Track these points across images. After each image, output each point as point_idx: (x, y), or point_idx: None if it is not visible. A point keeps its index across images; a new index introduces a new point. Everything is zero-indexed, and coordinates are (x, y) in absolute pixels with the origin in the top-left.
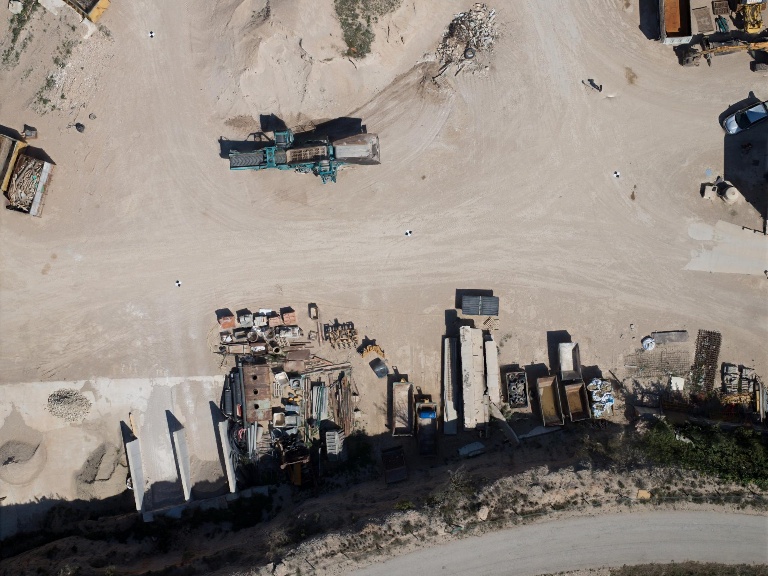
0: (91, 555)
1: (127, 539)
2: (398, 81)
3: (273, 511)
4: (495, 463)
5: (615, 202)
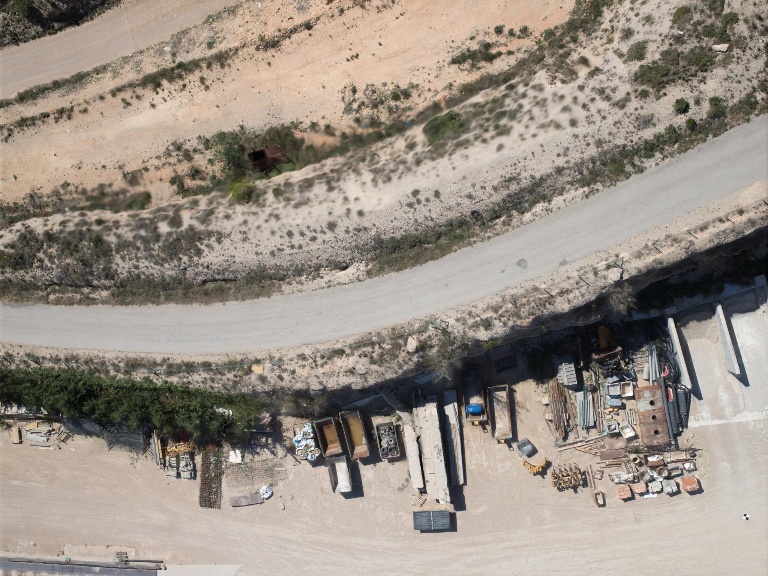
0: None
1: None
2: None
3: None
4: None
5: None
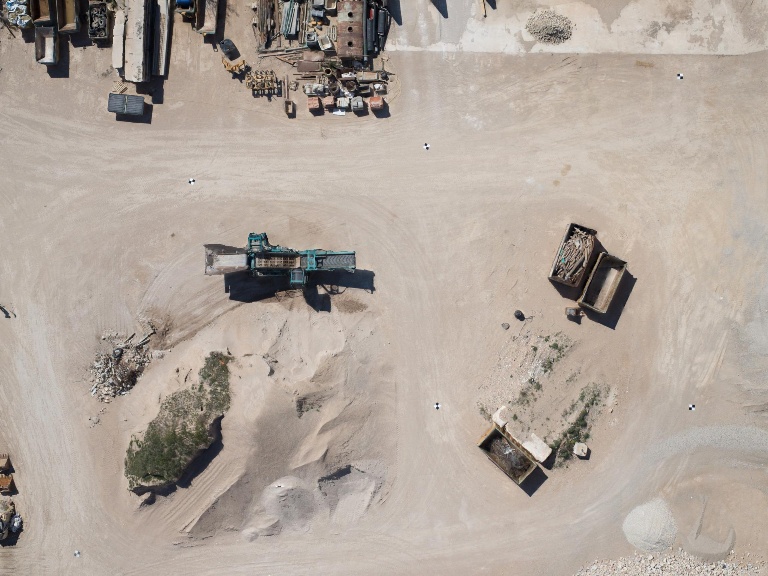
0: None
1: None
2: (191, 334)
3: None
4: None
5: None
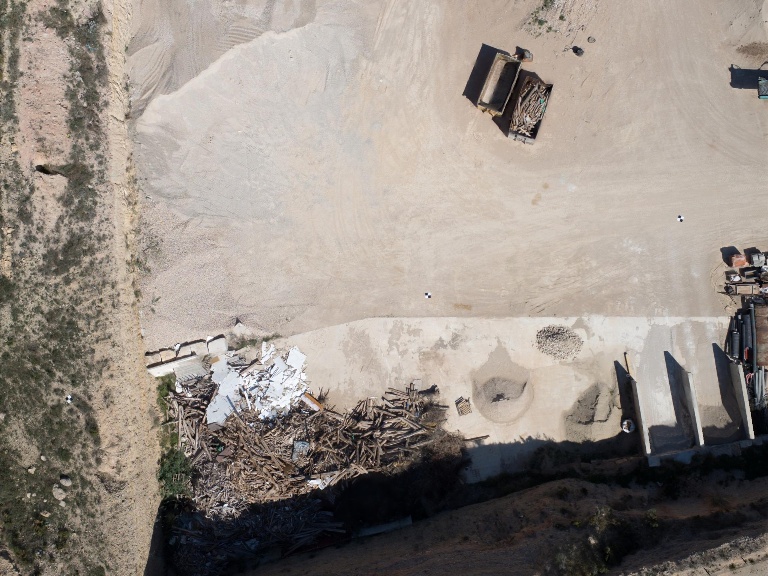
0: (605, 498)
1: (629, 484)
2: None
3: None
4: None
5: None
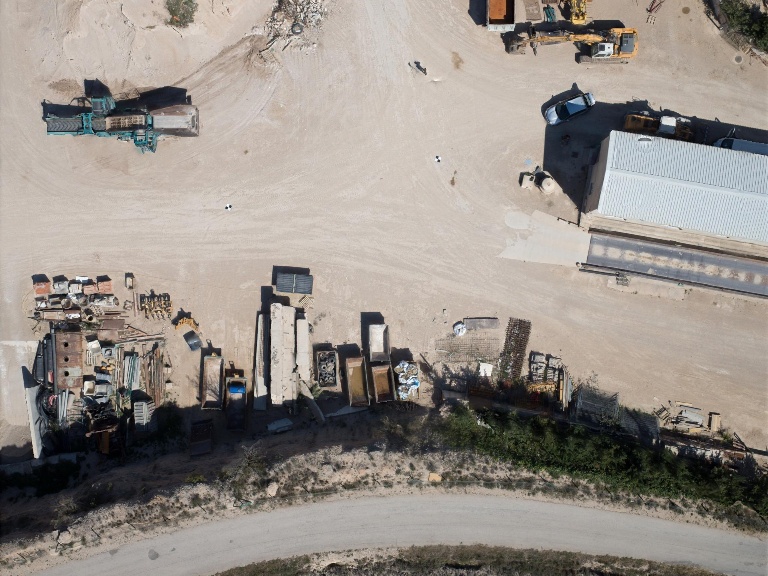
0: None
1: None
2: (225, 53)
3: (80, 478)
4: (297, 440)
5: (435, 187)
